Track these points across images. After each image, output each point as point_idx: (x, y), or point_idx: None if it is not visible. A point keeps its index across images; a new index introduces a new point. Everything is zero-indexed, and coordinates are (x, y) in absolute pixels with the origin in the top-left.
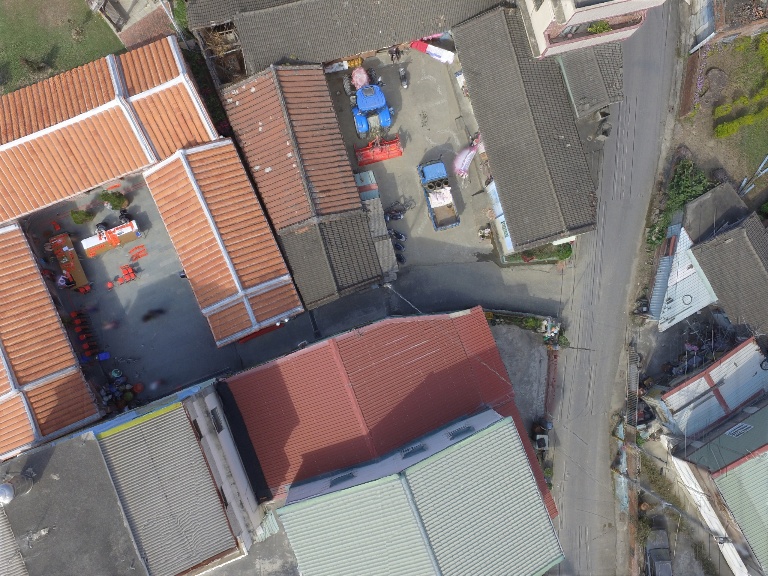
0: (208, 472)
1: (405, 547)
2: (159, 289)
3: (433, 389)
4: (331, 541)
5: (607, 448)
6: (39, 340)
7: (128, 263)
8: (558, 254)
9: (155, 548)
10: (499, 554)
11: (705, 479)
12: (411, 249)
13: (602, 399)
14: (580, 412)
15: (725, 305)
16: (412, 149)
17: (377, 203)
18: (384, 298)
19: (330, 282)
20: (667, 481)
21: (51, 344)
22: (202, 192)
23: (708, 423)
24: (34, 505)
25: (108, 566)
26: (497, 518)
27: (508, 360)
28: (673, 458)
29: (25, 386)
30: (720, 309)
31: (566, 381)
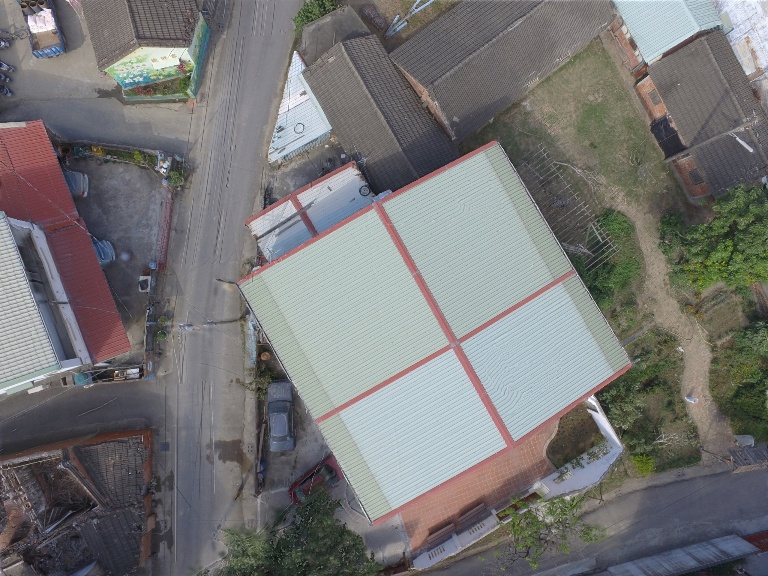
0: None
1: None
2: None
3: None
4: None
5: (237, 298)
6: None
7: None
8: None
9: None
10: None
11: None
12: (21, 82)
13: (233, 246)
14: (207, 259)
15: (338, 133)
16: None
17: None
18: None
19: None
20: None
21: None
22: None
23: None
24: None
25: None
26: None
27: (124, 201)
28: None
29: None
30: None
31: (192, 226)
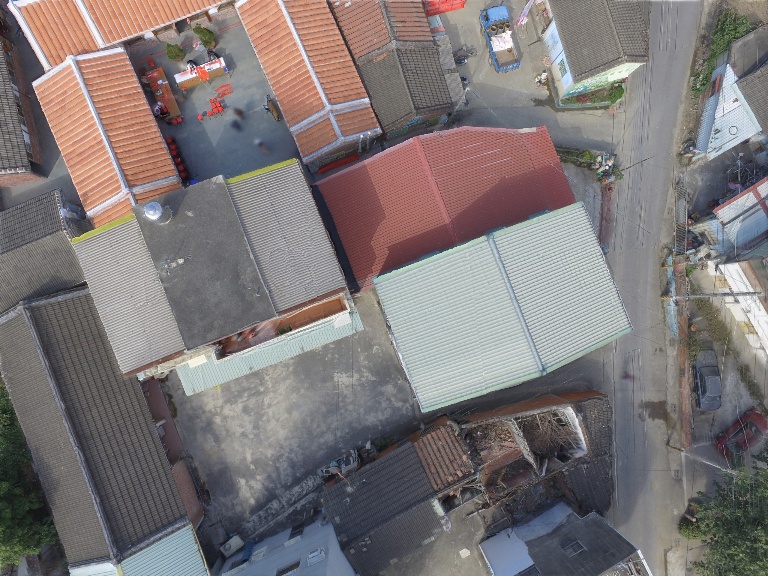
0: (320, 220)
1: (492, 303)
2: (243, 124)
3: (506, 192)
4: (423, 304)
5: (657, 279)
6: (144, 151)
7: None
8: (610, 97)
9: (280, 272)
10: (575, 317)
11: (758, 270)
12: None
13: (652, 233)
14: (632, 245)
15: None
16: (473, 2)
17: (446, 40)
18: None
19: (407, 102)
20: (714, 308)
21: (154, 155)
22: (291, 18)
23: (756, 234)
24: (171, 238)
25: (237, 293)
26: (573, 286)
27: None
28: (724, 267)
29: (134, 188)
30: (763, 142)
31: (618, 216)
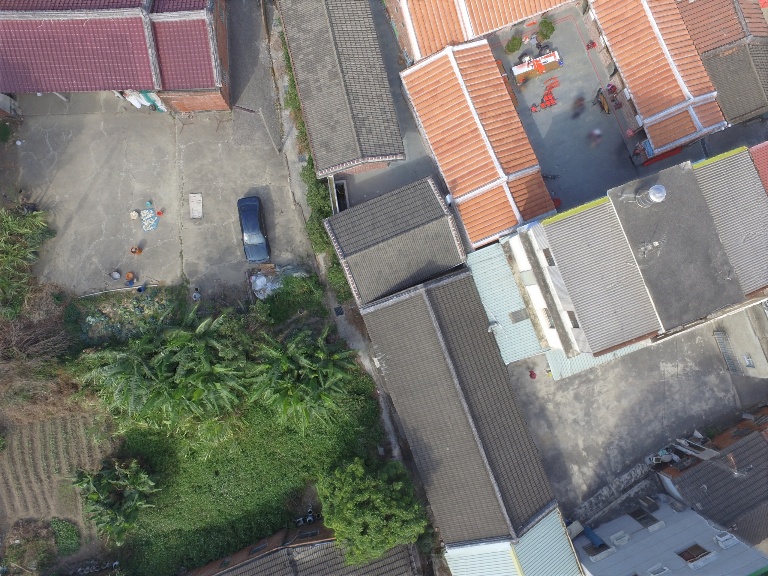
0: None
1: None
2: (570, 117)
3: None
4: None
5: None
6: (511, 140)
7: (543, 93)
8: None
9: (759, 256)
10: None
11: None
12: None
13: None
14: None
15: None
16: None
17: None
18: (763, 132)
19: (759, 96)
20: None
21: (519, 145)
22: (651, 12)
23: None
24: (646, 221)
25: (709, 276)
26: None
27: None
28: None
29: (509, 176)
30: None
31: None
